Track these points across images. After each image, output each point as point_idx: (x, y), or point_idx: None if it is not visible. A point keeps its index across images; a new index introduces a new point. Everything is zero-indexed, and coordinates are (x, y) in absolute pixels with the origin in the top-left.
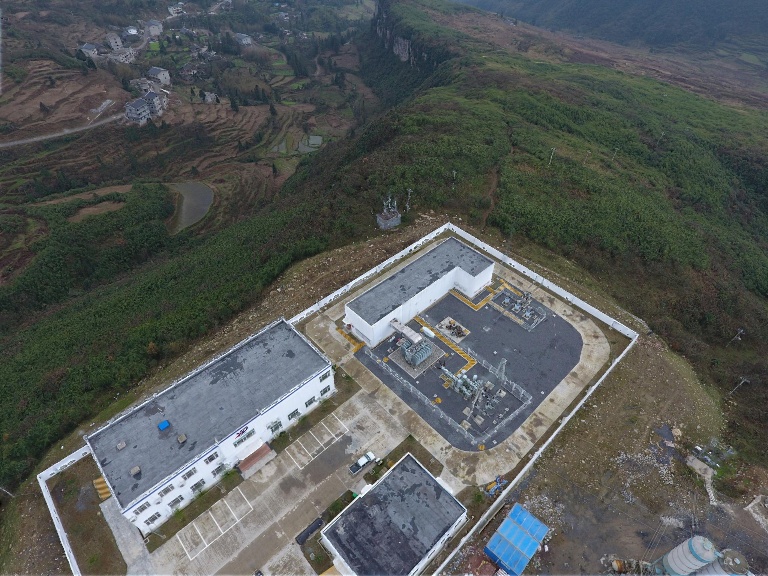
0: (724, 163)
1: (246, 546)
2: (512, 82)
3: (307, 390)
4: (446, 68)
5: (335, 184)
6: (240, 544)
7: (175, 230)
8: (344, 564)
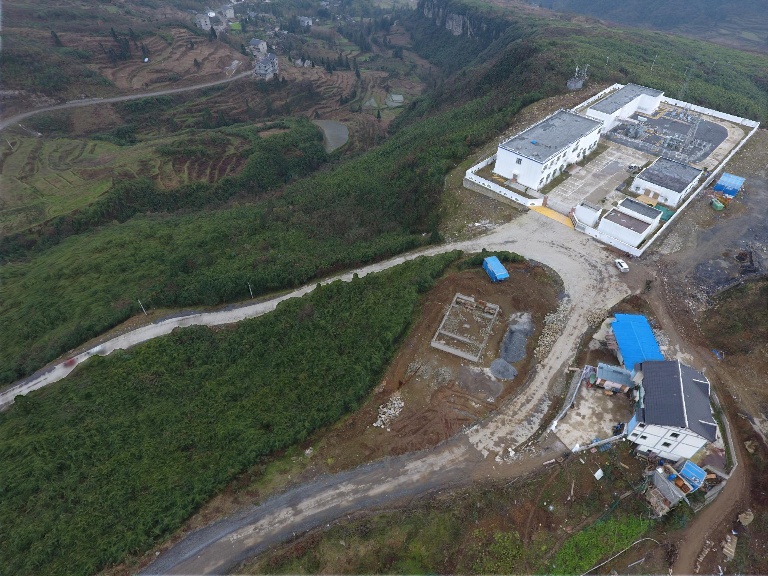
0: (760, 88)
1: (592, 192)
2: (587, 31)
3: (593, 136)
4: (517, 29)
5: (528, 68)
6: (588, 191)
7: (328, 150)
8: (652, 187)
